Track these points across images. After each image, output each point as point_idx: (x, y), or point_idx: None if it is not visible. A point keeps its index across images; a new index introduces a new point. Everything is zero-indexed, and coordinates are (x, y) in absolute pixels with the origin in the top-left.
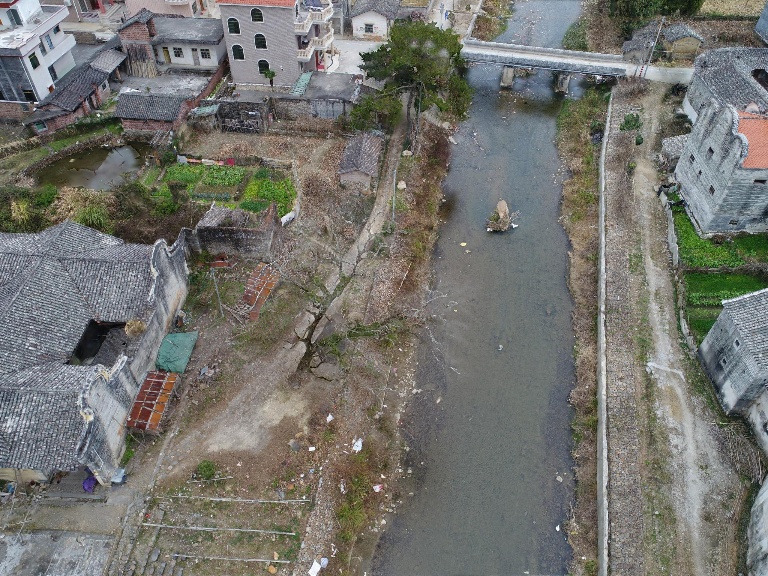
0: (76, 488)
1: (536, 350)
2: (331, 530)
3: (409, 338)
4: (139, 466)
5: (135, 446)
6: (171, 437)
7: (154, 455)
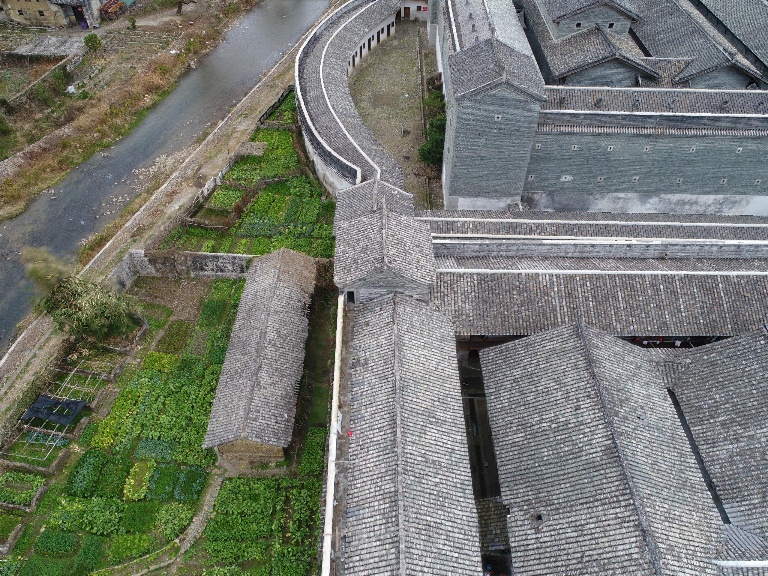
0: (79, 29)
1: (302, 18)
2: (183, 47)
3: (241, 13)
4: (105, 25)
5: (104, 21)
6: (120, 20)
7: (112, 23)
